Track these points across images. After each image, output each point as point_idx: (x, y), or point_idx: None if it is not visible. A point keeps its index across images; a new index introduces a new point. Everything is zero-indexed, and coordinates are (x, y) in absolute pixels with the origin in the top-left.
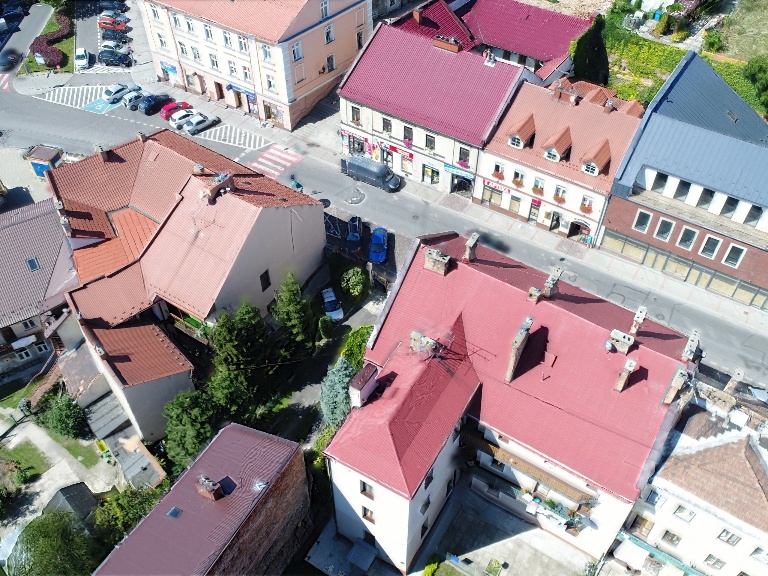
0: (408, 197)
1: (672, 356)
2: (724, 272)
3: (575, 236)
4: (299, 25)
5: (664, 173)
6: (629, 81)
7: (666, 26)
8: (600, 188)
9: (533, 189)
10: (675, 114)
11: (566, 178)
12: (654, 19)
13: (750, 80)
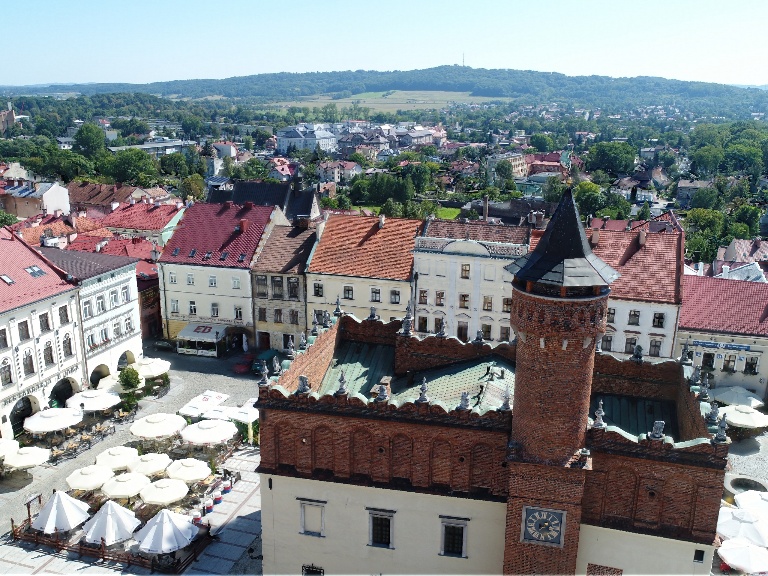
0: None
1: (594, 220)
2: None
3: None
4: None
5: None
6: None
7: None
8: None
9: None
10: None
11: None
12: None
13: None
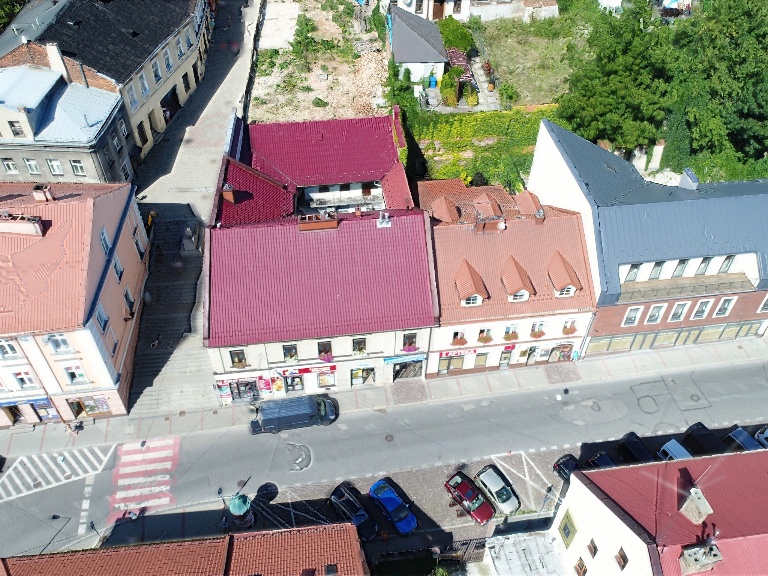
0: (356, 417)
1: None
2: (714, 323)
3: (551, 357)
4: (91, 284)
5: (639, 263)
6: (449, 160)
7: (459, 93)
8: (585, 306)
9: (506, 338)
10: (600, 196)
11: (546, 313)
12: (430, 87)
13: (565, 119)
